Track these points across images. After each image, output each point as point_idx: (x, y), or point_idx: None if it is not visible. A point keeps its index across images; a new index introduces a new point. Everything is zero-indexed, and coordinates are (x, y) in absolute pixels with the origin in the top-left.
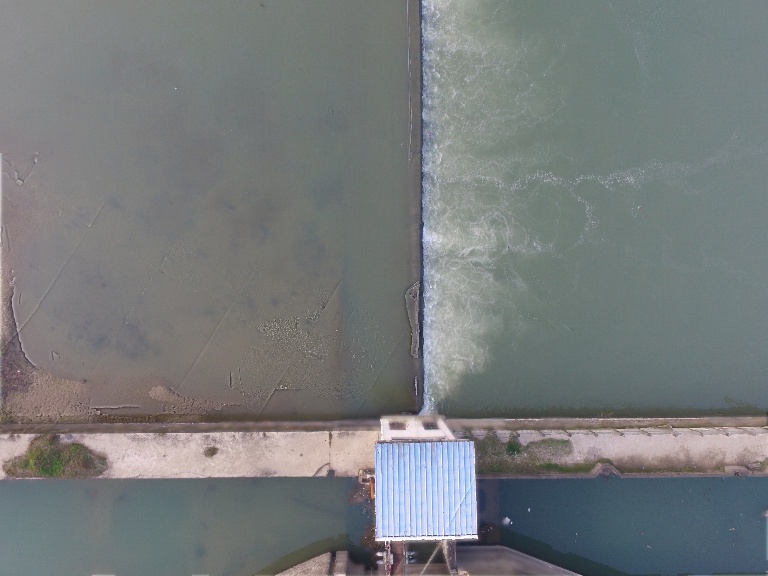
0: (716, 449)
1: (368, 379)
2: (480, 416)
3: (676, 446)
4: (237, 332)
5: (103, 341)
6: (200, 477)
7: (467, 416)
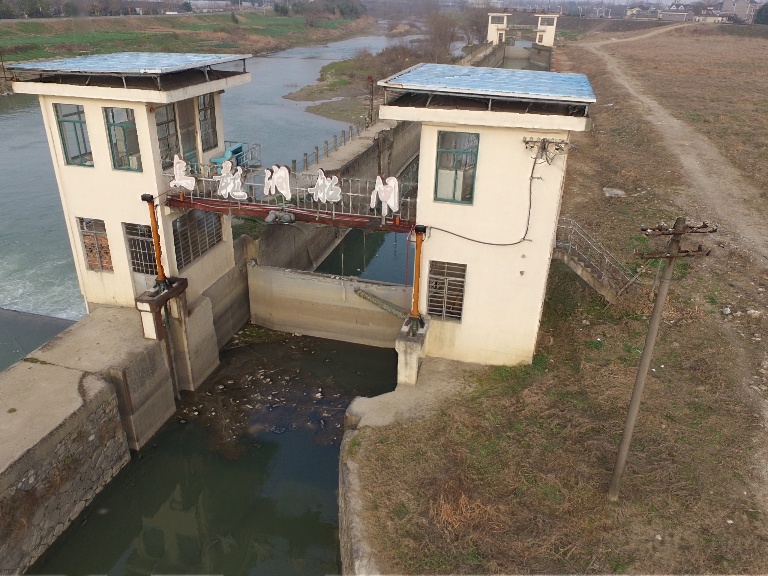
0: (353, 153)
1: None
2: None
3: (336, 162)
4: None
5: None
6: None
7: None
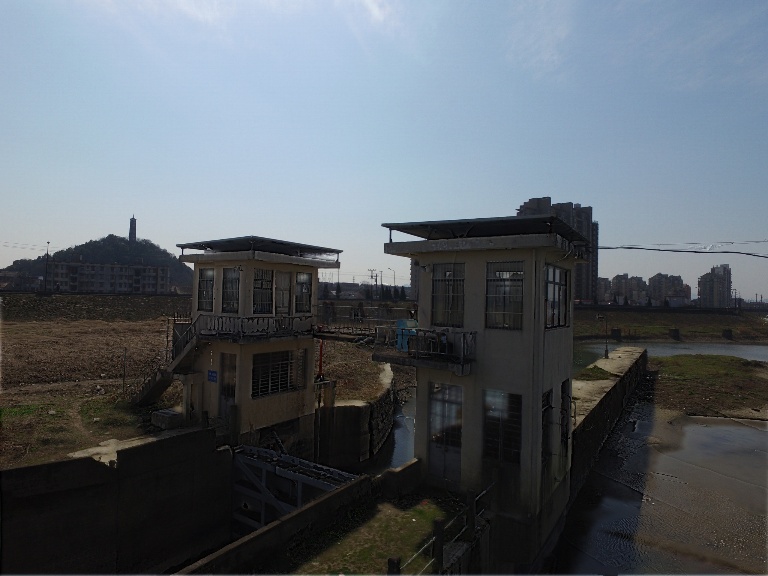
0: None
1: None
2: None
3: None
4: (761, 498)
5: (725, 440)
6: None
7: None
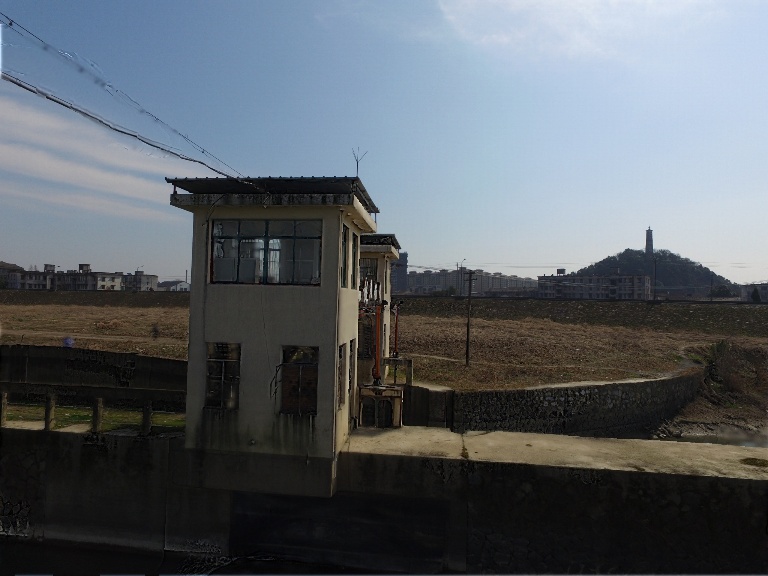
0: None
1: None
2: (78, 568)
3: None
4: None
5: None
6: None
7: (109, 573)
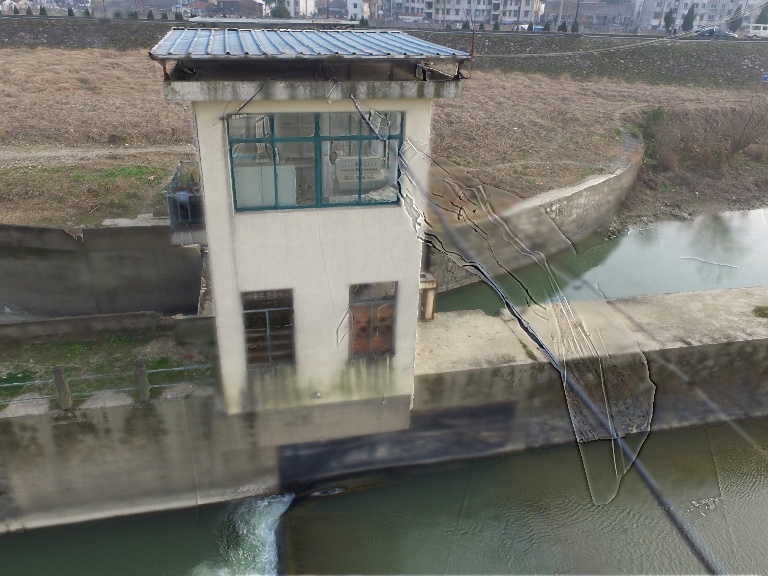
0: None
1: (472, 570)
2: (88, 545)
3: None
4: None
5: None
6: (745, 288)
7: (132, 540)
